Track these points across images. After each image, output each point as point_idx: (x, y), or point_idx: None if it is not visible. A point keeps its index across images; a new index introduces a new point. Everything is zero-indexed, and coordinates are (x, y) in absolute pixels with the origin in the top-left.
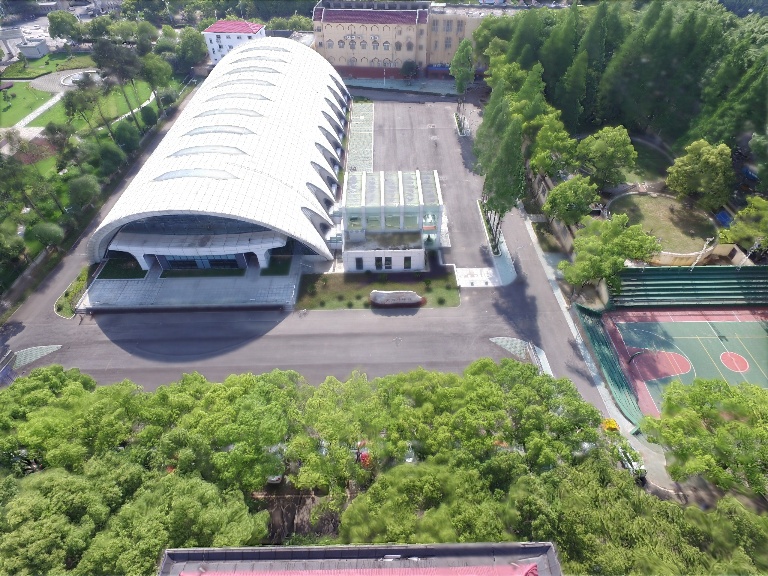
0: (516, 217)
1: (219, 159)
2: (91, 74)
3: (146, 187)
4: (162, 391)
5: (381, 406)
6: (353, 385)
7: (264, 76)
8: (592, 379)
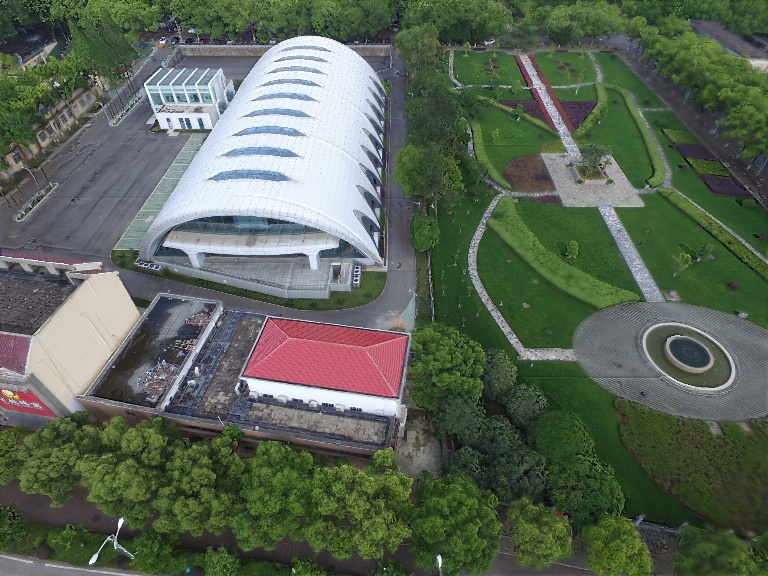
0: (103, 115)
1: (290, 54)
2: (684, 370)
3: (334, 50)
4: (294, 4)
5: (232, 6)
6: (240, 22)
7: (253, 122)
8: (152, 57)
